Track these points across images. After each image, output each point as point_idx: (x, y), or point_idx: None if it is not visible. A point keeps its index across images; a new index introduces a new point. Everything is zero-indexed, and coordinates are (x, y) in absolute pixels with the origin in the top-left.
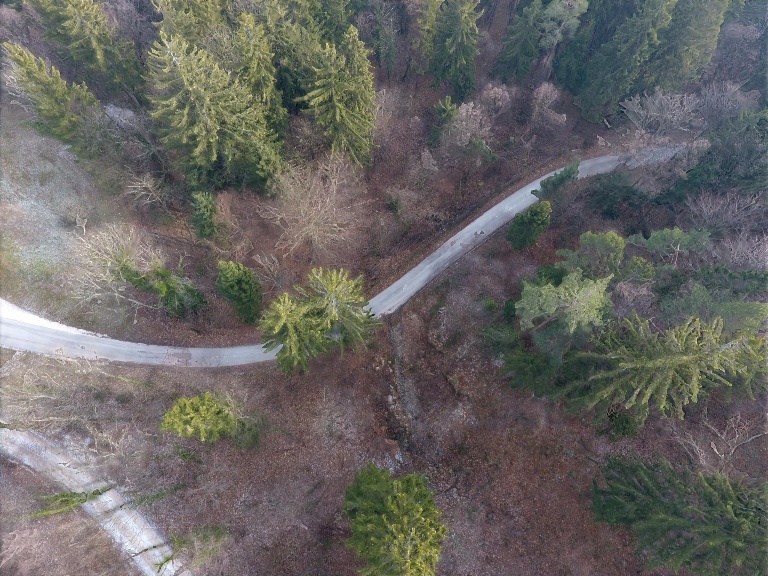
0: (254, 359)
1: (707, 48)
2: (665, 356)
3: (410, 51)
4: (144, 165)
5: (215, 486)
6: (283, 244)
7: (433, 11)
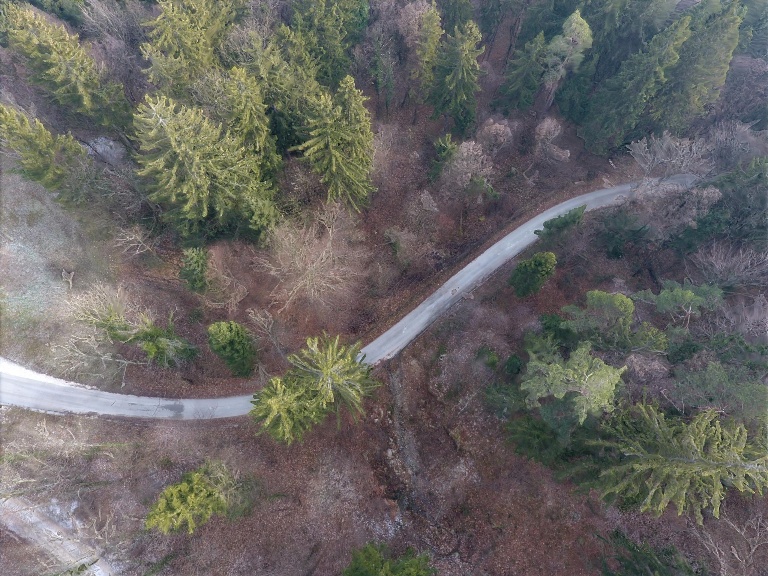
0: (249, 410)
1: (715, 84)
2: (684, 466)
3: (409, 81)
4: (133, 212)
5: (207, 552)
6: (278, 293)
7: (432, 43)
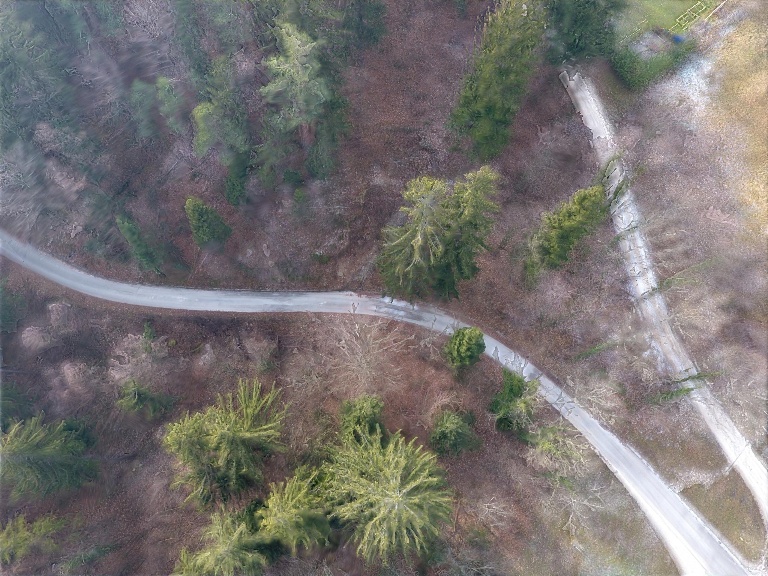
0: None
1: None
2: None
3: None
4: None
5: None
6: None
7: (1, 534)
